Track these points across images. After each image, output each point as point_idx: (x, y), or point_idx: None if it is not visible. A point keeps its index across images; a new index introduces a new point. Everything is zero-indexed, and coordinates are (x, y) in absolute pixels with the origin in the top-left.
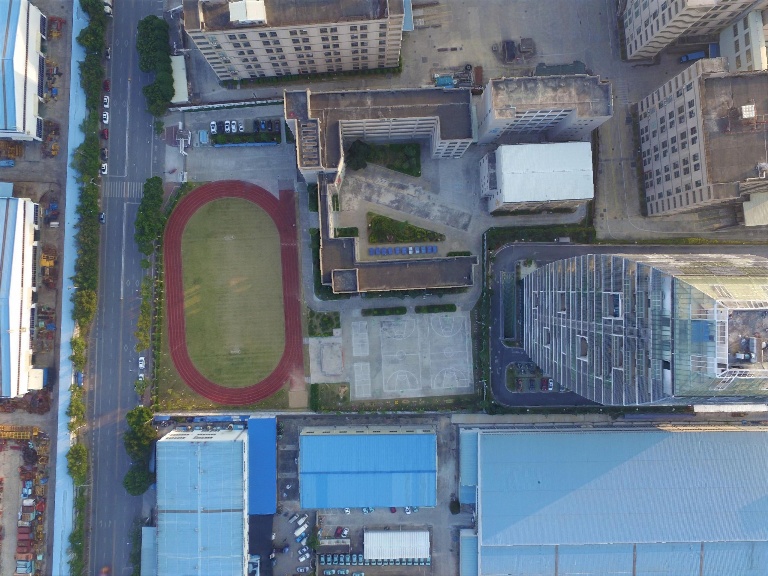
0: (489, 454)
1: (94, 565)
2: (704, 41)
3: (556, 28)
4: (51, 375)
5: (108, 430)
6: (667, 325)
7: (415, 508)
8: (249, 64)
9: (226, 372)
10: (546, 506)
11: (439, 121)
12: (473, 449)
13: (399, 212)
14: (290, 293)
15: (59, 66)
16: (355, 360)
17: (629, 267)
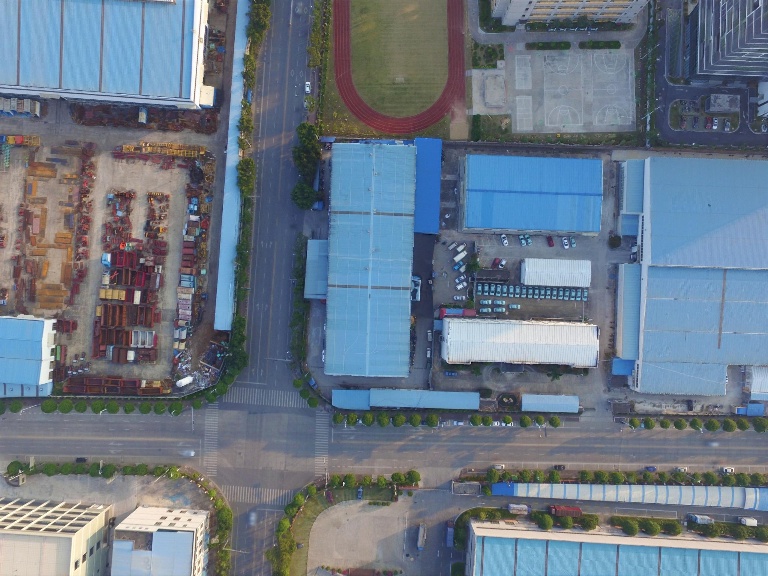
0: (659, 176)
1: (254, 284)
2: None
3: None
4: (219, 97)
5: (272, 153)
6: None
7: (574, 242)
8: None
9: (389, 101)
10: (716, 229)
11: None
12: (639, 176)
13: None
14: (454, 26)
15: None
16: (517, 93)
17: None
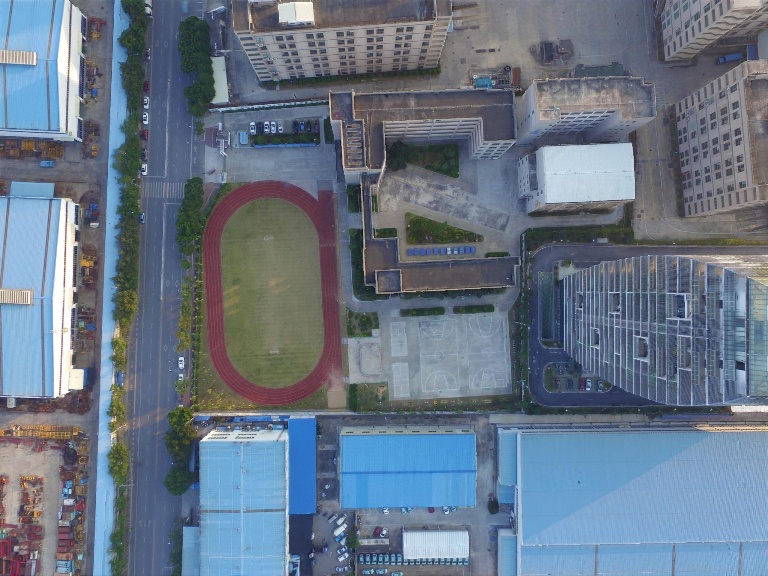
0: (529, 454)
1: (134, 565)
2: (742, 42)
3: (594, 29)
4: (91, 375)
5: (148, 430)
6: (741, 326)
7: (453, 508)
8: (291, 65)
9: (265, 372)
10: (586, 506)
11: (482, 122)
12: (512, 449)
13: (437, 213)
14: (329, 293)
15: (99, 67)
16: (394, 360)
17: (698, 268)
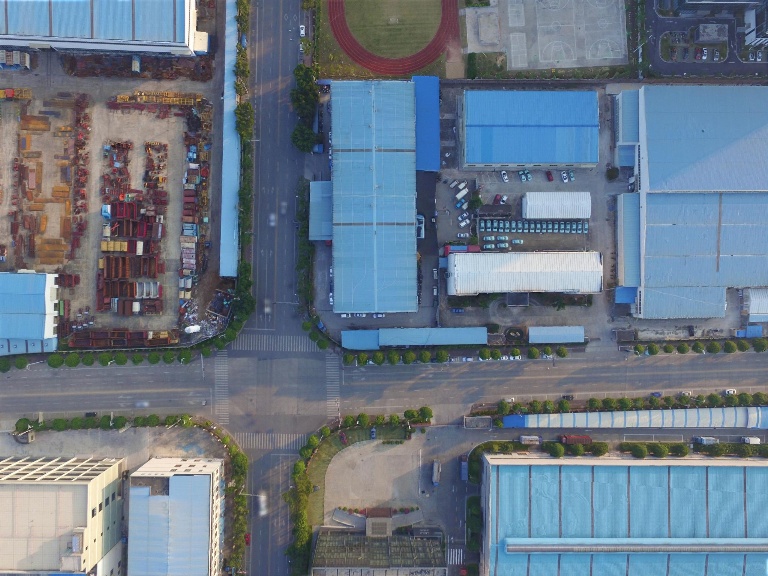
0: (653, 104)
1: (258, 231)
2: None
3: None
4: (213, 43)
5: (270, 98)
6: None
7: (572, 176)
8: None
9: (384, 43)
10: (711, 154)
11: None
12: (634, 106)
13: None
14: None
15: None
16: (511, 30)
17: None
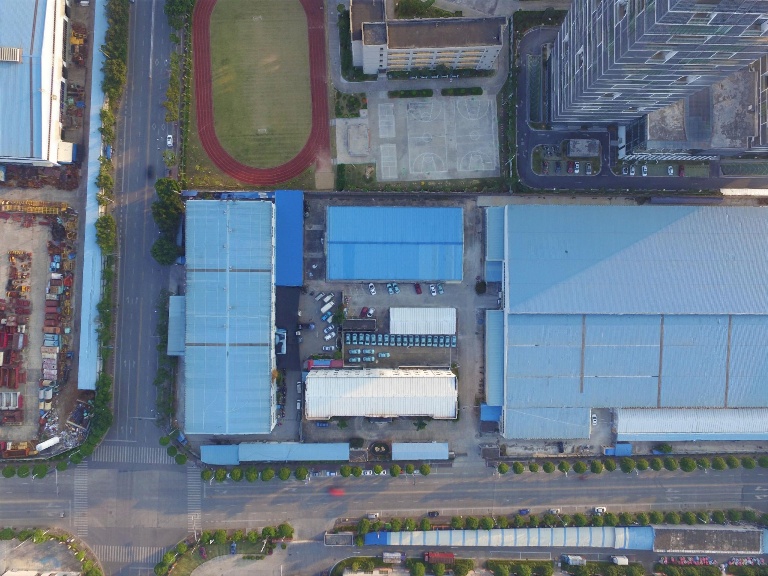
0: (516, 224)
1: (121, 341)
2: None
3: None
4: (80, 152)
5: (136, 207)
6: None
7: (441, 289)
8: None
9: (253, 152)
10: (573, 275)
11: None
12: (500, 223)
13: None
14: (317, 75)
15: None
16: (381, 142)
17: None
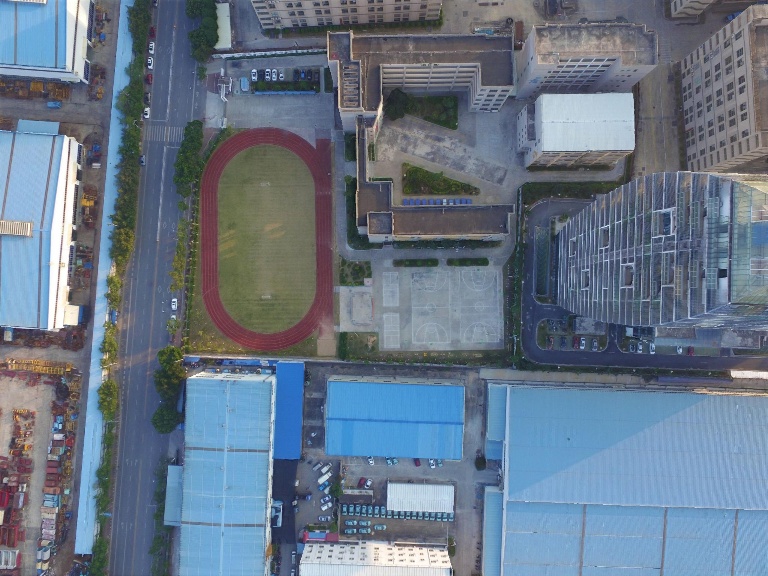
0: (518, 408)
1: (119, 503)
2: None
3: None
4: (86, 313)
5: (139, 369)
6: (725, 231)
7: (440, 462)
8: (293, 10)
9: (256, 317)
10: (575, 464)
11: (480, 67)
12: (502, 403)
13: (434, 164)
14: (323, 241)
15: (108, 12)
16: (385, 310)
17: (684, 179)
